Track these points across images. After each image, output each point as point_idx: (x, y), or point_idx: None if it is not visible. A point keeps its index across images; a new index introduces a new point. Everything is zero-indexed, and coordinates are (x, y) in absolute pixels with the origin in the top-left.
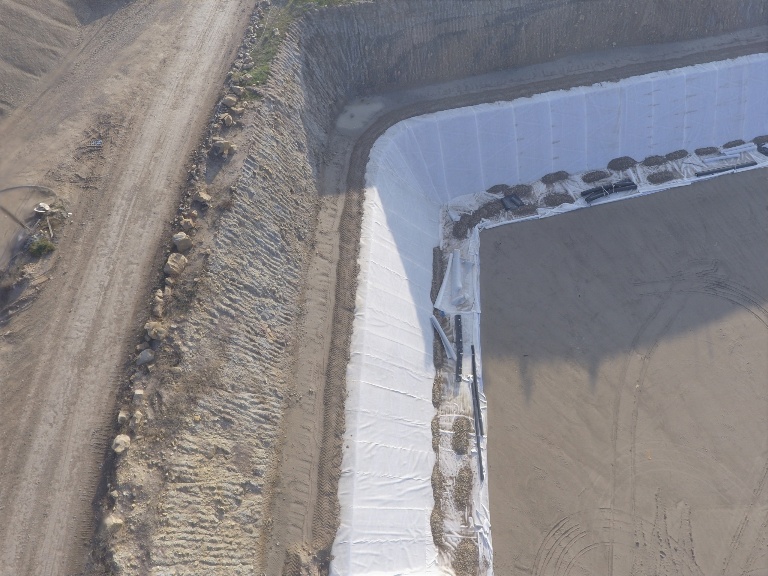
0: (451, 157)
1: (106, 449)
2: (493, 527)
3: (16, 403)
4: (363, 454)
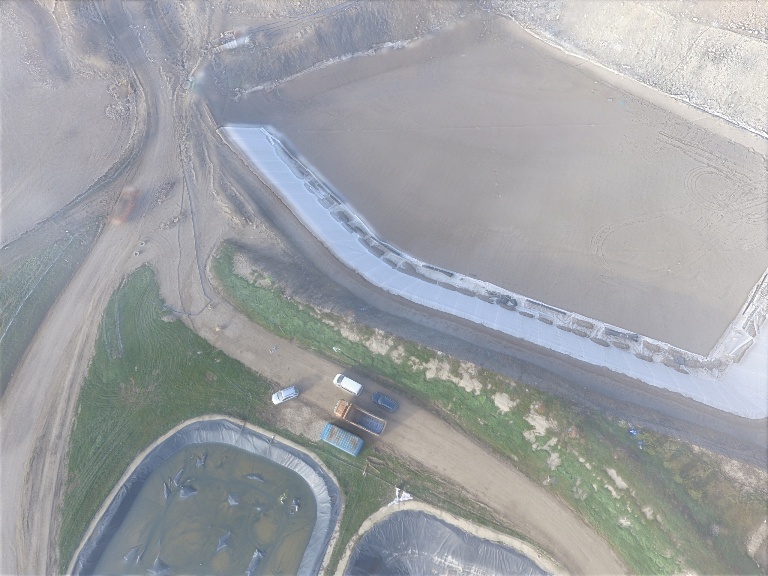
0: None
1: None
2: None
3: None
4: None
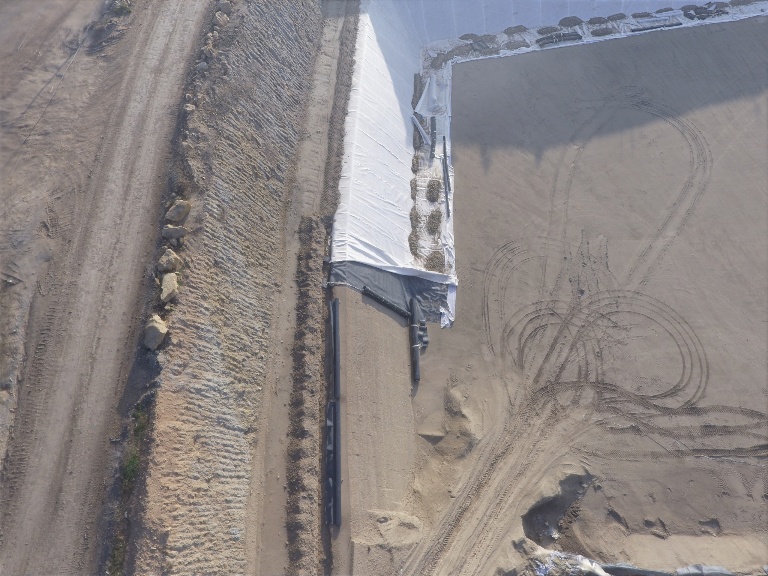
0: (429, 6)
1: (178, 115)
2: (456, 245)
3: (113, 91)
4: (357, 170)
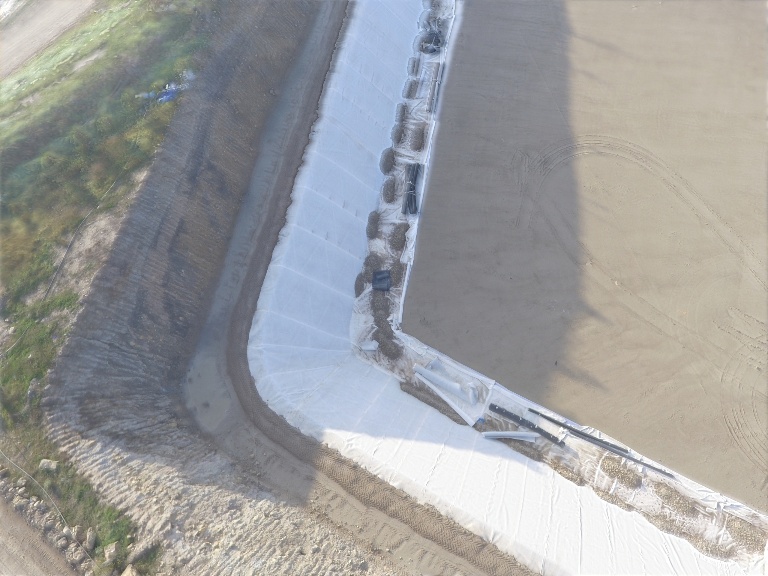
0: (310, 315)
1: None
2: (720, 491)
3: None
4: None
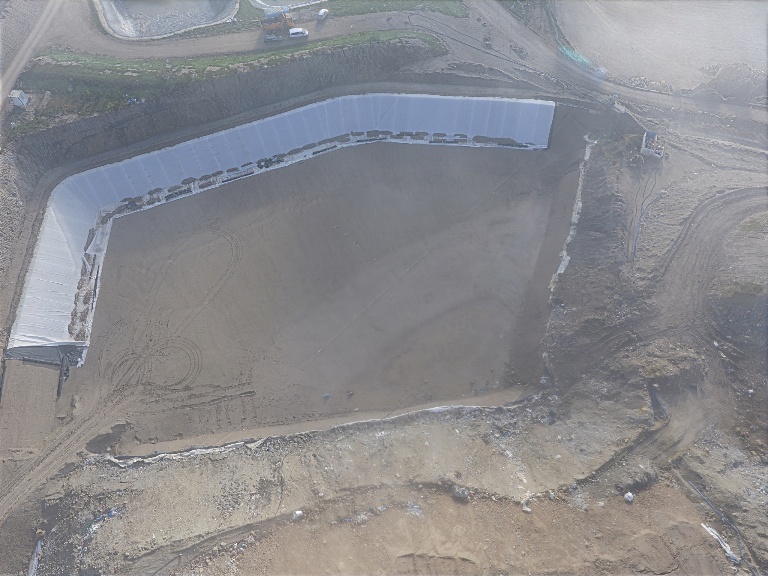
0: (97, 189)
1: None
2: (93, 326)
3: None
4: (29, 300)
